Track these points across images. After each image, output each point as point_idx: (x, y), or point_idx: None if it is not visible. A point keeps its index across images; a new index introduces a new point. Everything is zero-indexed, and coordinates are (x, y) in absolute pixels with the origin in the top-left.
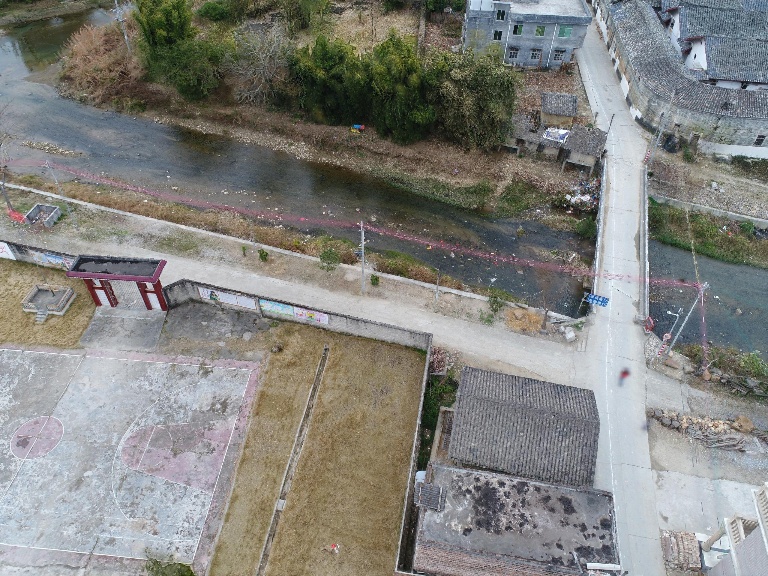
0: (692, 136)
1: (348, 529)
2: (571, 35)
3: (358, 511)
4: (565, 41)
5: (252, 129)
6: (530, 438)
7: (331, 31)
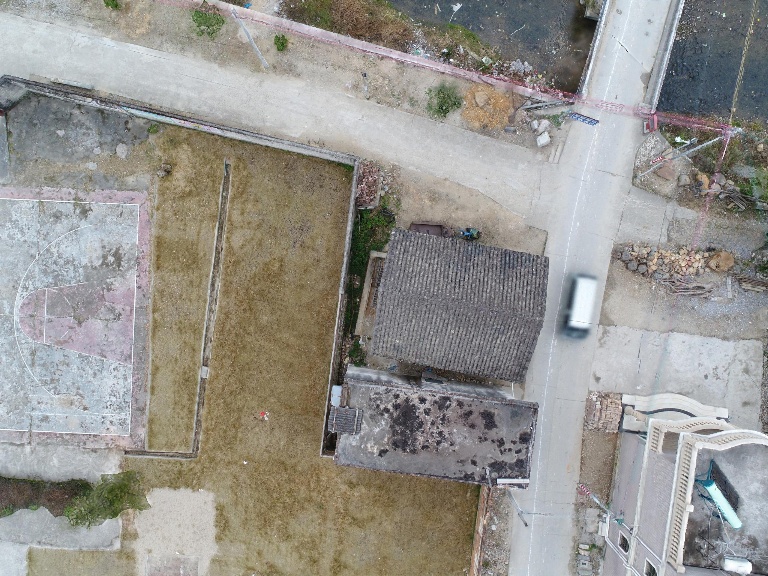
0: None
1: (275, 397)
2: None
3: (284, 378)
4: None
5: None
6: (462, 335)
7: None
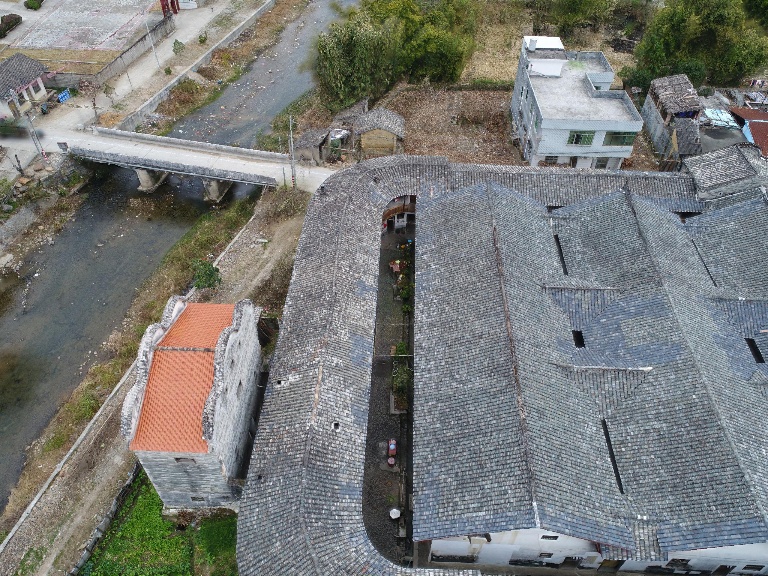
0: None
1: None
2: None
3: None
4: None
5: None
6: None
7: None
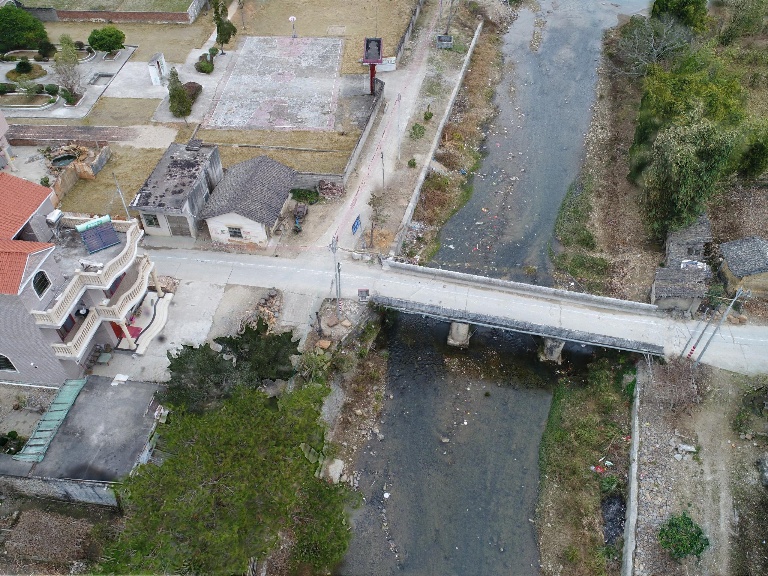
0: None
1: None
2: None
3: None
4: None
5: (613, 107)
6: None
7: None
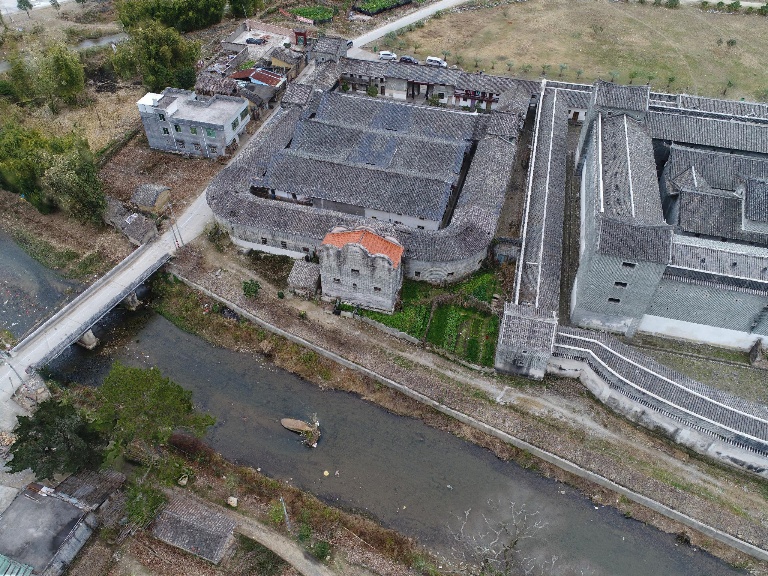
0: (225, 232)
1: None
2: (216, 136)
3: None
4: (213, 140)
5: None
6: None
7: (91, 108)
